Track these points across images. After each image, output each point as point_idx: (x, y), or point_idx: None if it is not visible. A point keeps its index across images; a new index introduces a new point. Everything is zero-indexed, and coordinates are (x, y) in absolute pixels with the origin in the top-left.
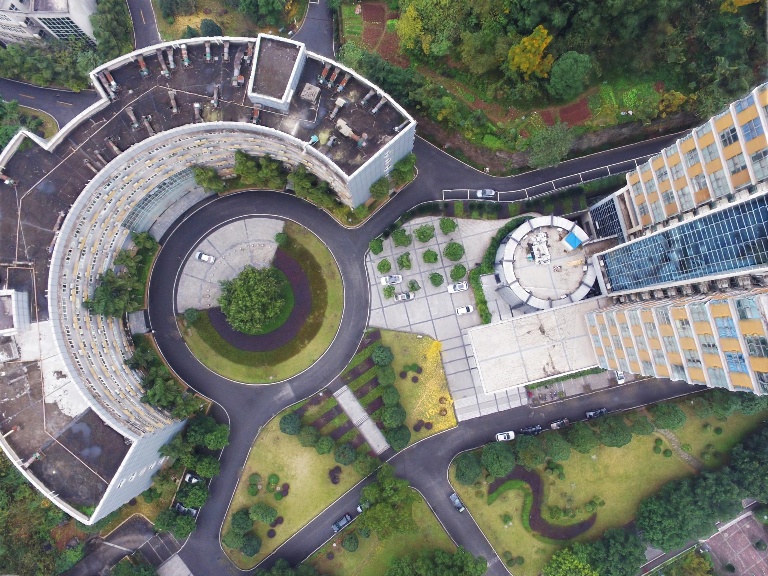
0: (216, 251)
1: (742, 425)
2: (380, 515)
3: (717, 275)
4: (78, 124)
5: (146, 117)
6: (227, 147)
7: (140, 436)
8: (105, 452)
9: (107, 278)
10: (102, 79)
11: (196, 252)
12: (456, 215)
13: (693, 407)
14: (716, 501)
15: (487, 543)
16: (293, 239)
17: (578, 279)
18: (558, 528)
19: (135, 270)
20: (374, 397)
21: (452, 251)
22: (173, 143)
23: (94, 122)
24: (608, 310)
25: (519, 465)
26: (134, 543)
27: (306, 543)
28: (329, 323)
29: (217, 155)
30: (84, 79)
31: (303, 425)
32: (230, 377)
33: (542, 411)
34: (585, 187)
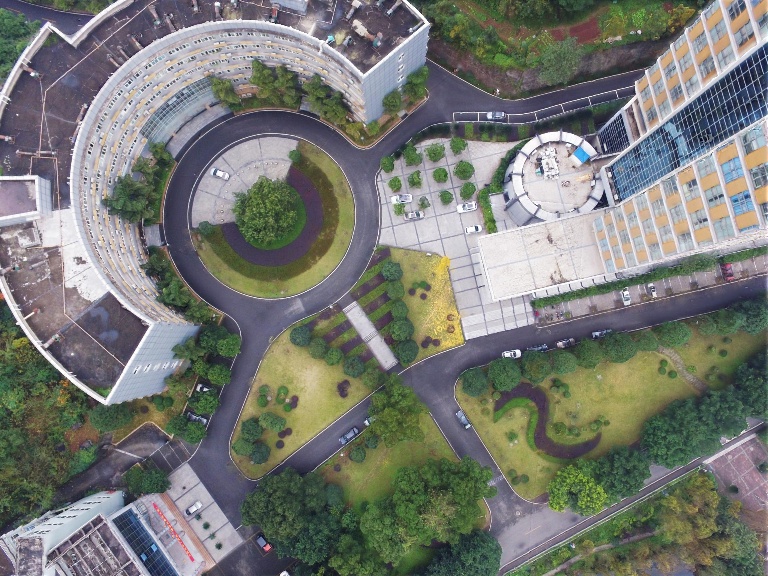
0: (230, 168)
1: (747, 348)
2: (388, 418)
3: (724, 144)
4: (102, 21)
5: (168, 14)
6: (245, 54)
7: (156, 321)
8: (122, 336)
9: (126, 181)
10: None
11: (211, 168)
12: (466, 137)
13: (698, 326)
14: (720, 418)
15: (492, 461)
16: (306, 158)
17: (586, 194)
18: (563, 447)
19: (152, 180)
20: (383, 313)
21: (462, 168)
22: (193, 44)
23: (117, 20)
24: (616, 208)
25: (525, 383)
26: (145, 451)
27: (314, 455)
28: (340, 240)
29: (234, 65)
30: (105, 1)
31: (313, 338)
32: (242, 291)
33: None
34: (594, 110)
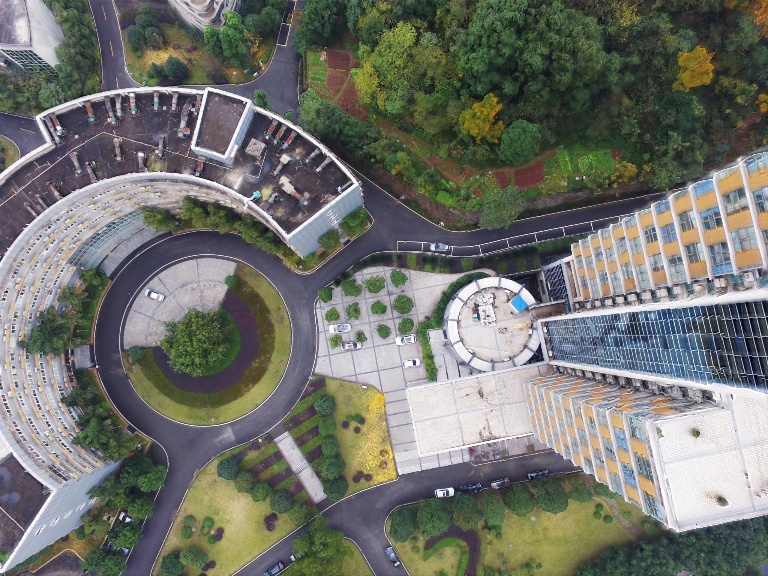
0: (166, 289)
1: None
2: (307, 571)
3: (632, 373)
4: (21, 166)
5: (89, 164)
6: (175, 193)
7: (61, 484)
8: (24, 498)
9: (47, 316)
10: (48, 123)
11: (146, 289)
12: (409, 267)
13: None
14: (651, 573)
15: None
16: (244, 281)
17: (523, 342)
18: None
19: (80, 307)
20: (315, 445)
21: (400, 305)
22: (117, 189)
23: (38, 165)
24: (540, 384)
25: None
26: None
27: None
28: (275, 368)
29: (166, 199)
30: None
31: (241, 470)
32: (172, 417)
33: (484, 469)
34: (539, 247)
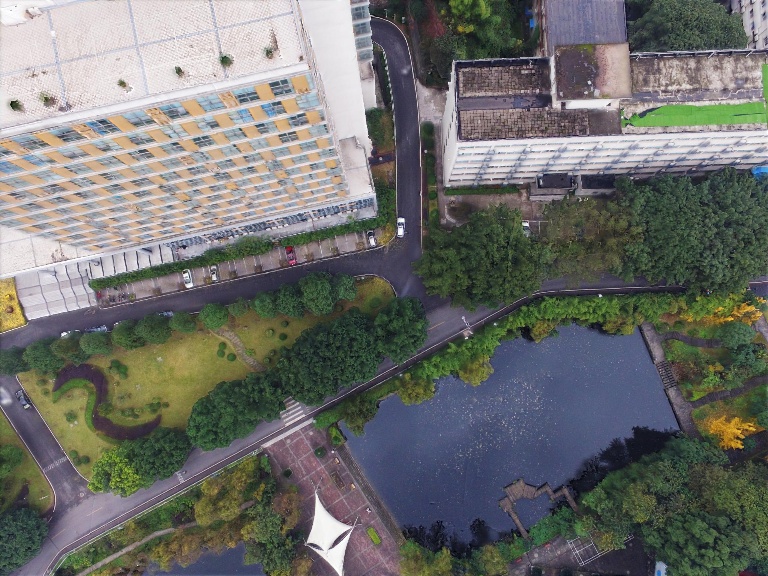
0: None
1: None
2: None
3: None
4: None
5: None
6: None
7: None
8: None
9: None
10: None
11: None
12: None
13: None
14: (253, 400)
15: (56, 442)
16: None
17: None
18: (122, 428)
19: None
20: None
21: None
22: None
23: None
24: None
25: (83, 364)
26: None
27: None
28: None
29: None
30: None
31: None
32: None
33: (112, 312)
34: None
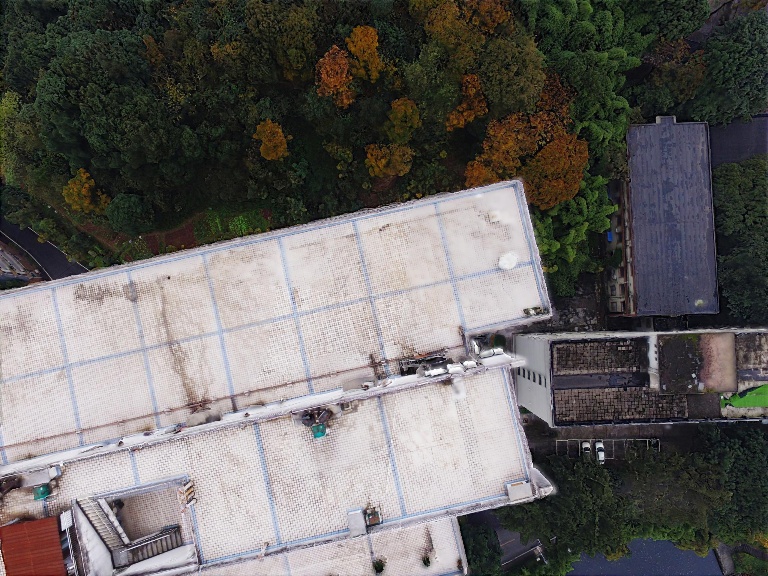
0: None
1: None
2: None
3: None
4: None
5: None
6: None
7: None
8: None
9: None
10: None
11: None
12: None
13: None
14: None
15: None
16: None
17: None
18: None
19: None
20: None
21: None
22: None
23: None
24: None
25: None
26: None
27: None
28: None
29: None
30: None
31: None
32: None
33: None
34: None
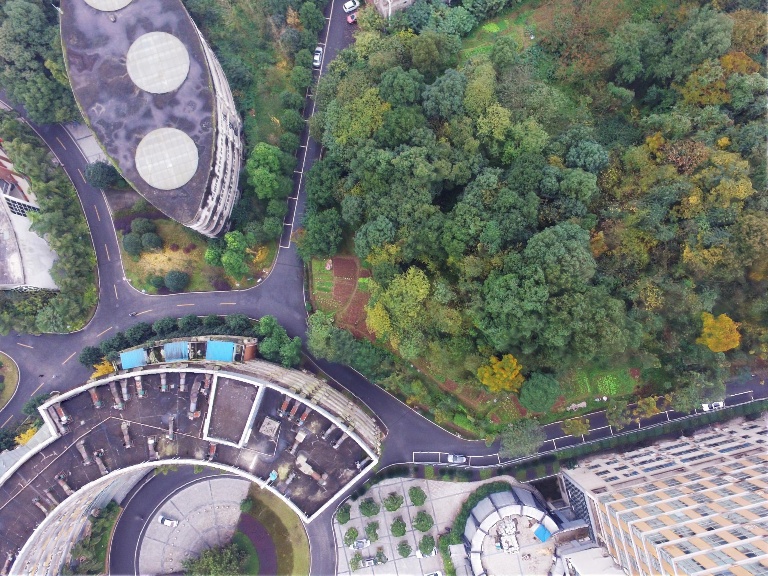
0: (179, 513)
1: None
2: None
3: None
4: (27, 460)
5: (98, 455)
6: None
7: None
8: None
9: None
10: (52, 414)
11: (159, 516)
12: (426, 478)
13: None
14: None
15: None
16: (259, 501)
17: (547, 568)
18: None
19: (93, 552)
20: None
21: (420, 528)
22: None
23: (44, 455)
24: None
25: None
26: None
27: None
28: None
29: None
30: None
31: None
32: None
33: None
34: (558, 455)
